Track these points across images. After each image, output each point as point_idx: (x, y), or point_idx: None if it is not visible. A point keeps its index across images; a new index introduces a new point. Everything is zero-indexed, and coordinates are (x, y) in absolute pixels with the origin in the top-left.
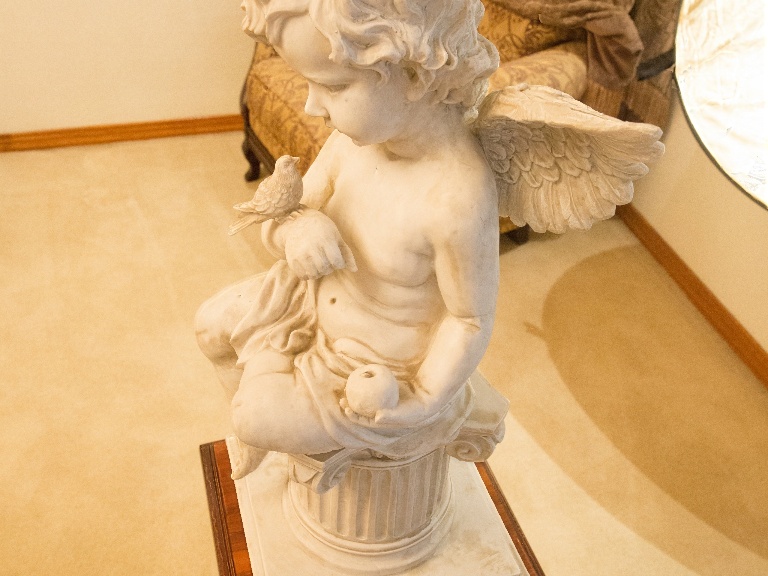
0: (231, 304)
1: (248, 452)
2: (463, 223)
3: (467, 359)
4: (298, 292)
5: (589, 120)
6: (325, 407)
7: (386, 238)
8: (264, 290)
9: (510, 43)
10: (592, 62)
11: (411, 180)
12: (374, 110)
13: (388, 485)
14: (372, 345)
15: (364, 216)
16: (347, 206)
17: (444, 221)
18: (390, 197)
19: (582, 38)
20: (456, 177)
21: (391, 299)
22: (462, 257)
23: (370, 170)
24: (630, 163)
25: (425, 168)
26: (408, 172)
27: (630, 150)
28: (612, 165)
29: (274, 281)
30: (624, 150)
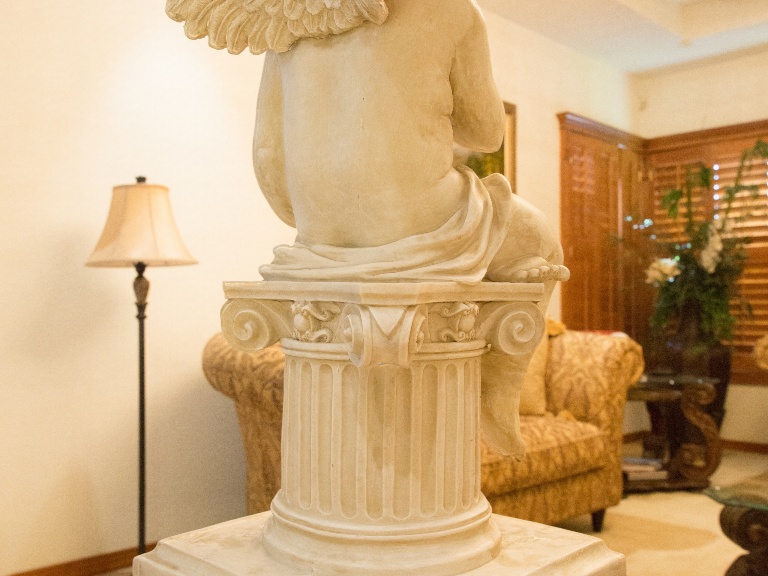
0: None
1: None
2: None
3: None
4: None
5: None
6: None
7: None
8: None
9: None
10: None
11: None
12: None
13: None
14: None
15: None
16: None
17: None
18: None
19: None
20: None
21: None
22: None
23: None
24: None
25: None
26: None
27: None
28: None
29: None
30: None
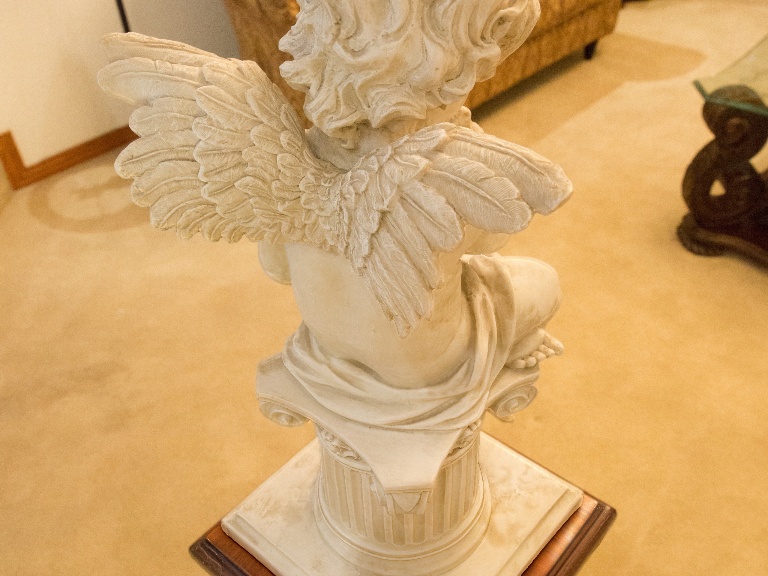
0: None
1: None
2: None
3: None
4: None
5: None
6: None
7: None
8: None
9: None
10: None
11: None
12: None
13: None
14: None
15: None
16: None
17: None
18: None
19: None
20: None
21: None
22: None
23: None
24: None
25: None
26: None
27: None
28: None
29: None
30: None
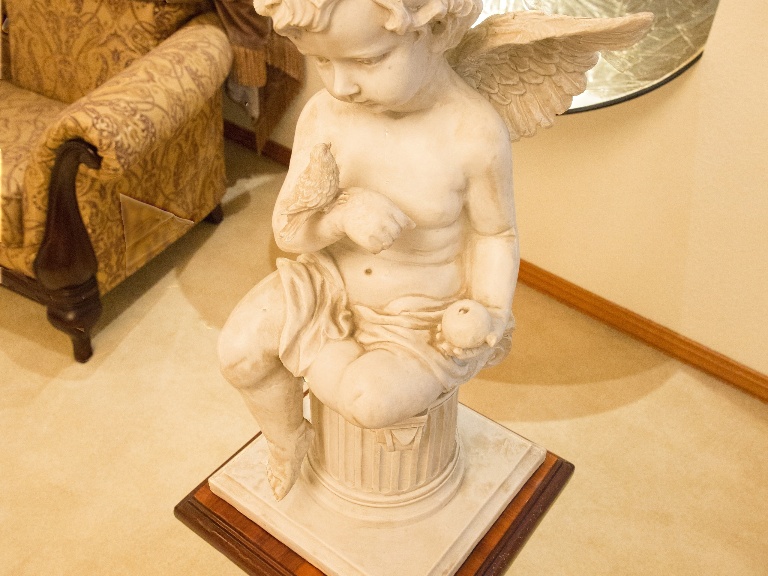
0: (261, 321)
1: (291, 465)
2: (499, 147)
3: (516, 266)
4: (318, 282)
5: (599, 22)
6: (432, 359)
7: (430, 187)
8: (291, 293)
9: (142, 31)
10: (229, 28)
11: (433, 128)
12: (413, 70)
13: (441, 420)
14: (427, 293)
15: (392, 178)
16: (366, 176)
17: (484, 151)
18: (419, 150)
19: (209, 8)
20: (476, 111)
21: (436, 243)
22: (500, 178)
23: (379, 135)
24: (591, 56)
25: (441, 113)
26: (426, 122)
27: (620, 40)
28: (577, 62)
29: (293, 281)
30: (614, 42)
